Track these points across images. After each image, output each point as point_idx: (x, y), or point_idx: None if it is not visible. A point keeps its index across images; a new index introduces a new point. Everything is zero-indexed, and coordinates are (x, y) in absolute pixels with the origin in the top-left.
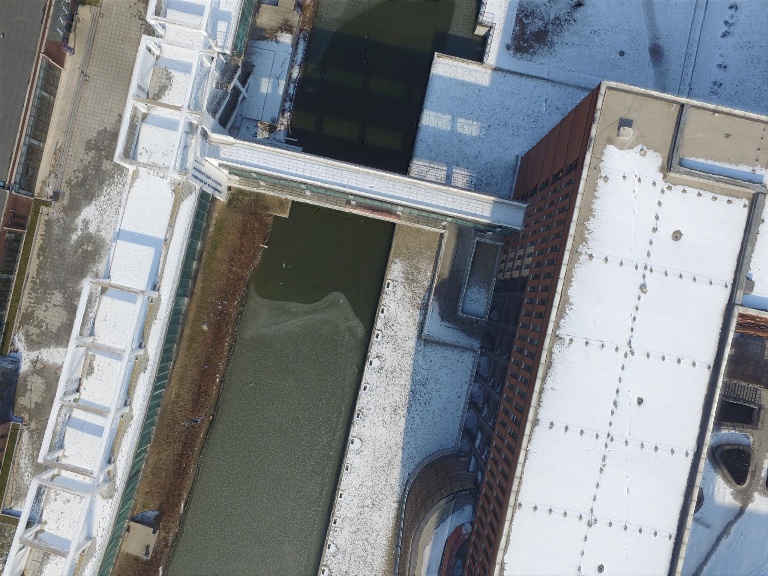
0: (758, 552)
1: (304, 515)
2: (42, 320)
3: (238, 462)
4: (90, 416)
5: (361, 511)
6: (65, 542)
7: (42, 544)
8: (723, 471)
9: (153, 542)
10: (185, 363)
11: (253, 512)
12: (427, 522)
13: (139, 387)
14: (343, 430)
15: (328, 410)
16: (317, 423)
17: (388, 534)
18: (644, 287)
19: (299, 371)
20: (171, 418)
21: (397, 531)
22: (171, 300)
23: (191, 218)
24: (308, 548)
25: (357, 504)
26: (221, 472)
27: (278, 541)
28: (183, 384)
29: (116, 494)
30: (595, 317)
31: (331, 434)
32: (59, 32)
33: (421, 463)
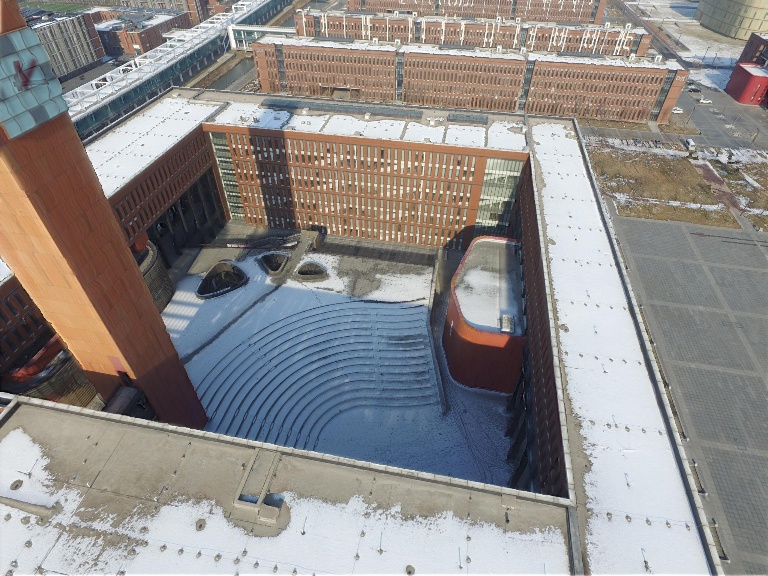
0: (284, 310)
1: None
2: None
3: None
4: None
5: None
6: None
7: None
8: (264, 265)
9: None
10: None
11: None
12: None
13: None
14: None
15: None
16: None
17: None
18: (163, 121)
19: None
20: None
21: None
22: None
23: None
24: None
25: None
26: None
27: None
28: None
29: None
30: (135, 127)
31: None
32: None
33: None
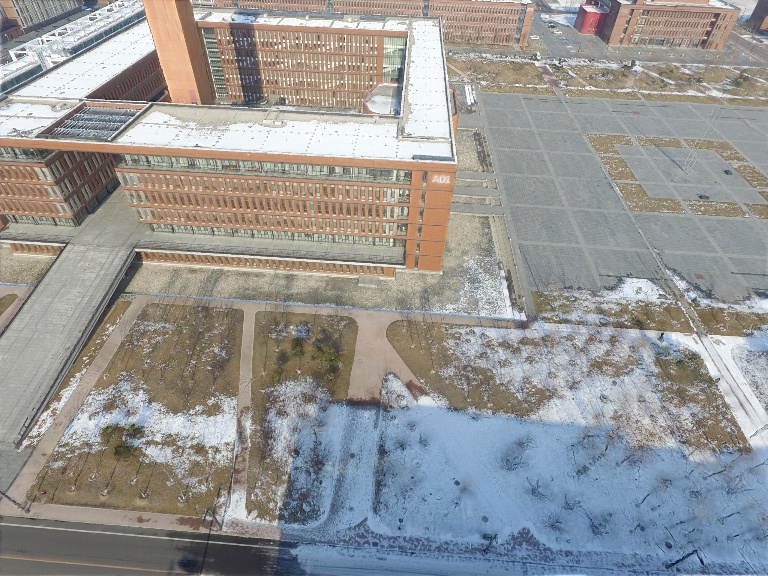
0: None
1: None
2: None
3: None
4: None
5: None
6: None
7: None
8: None
9: None
10: None
11: None
12: None
13: None
14: None
15: None
16: None
17: None
18: None
19: None
20: None
21: None
22: (9, 78)
23: (32, 67)
24: None
25: None
26: None
27: None
28: None
29: None
30: None
31: None
32: (8, 56)
33: None
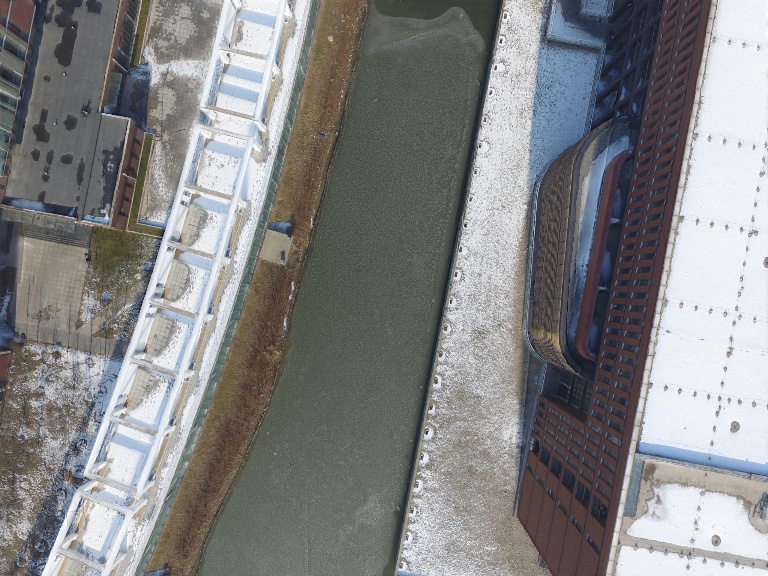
0: None
1: (432, 227)
2: (171, 33)
3: (365, 177)
4: (241, 81)
5: (491, 213)
6: (220, 206)
7: (198, 208)
8: None
9: (288, 248)
10: (313, 73)
11: (381, 226)
12: (588, 147)
13: (288, 51)
14: (467, 143)
15: (452, 123)
16: (441, 136)
17: (518, 235)
18: None
19: (422, 86)
20: (300, 128)
21: (527, 232)
22: None
23: None
24: (437, 260)
25: (487, 207)
26: (348, 187)
27: (407, 253)
28: (311, 94)
29: (269, 157)
30: None
31: (455, 147)
32: None
33: (550, 161)
